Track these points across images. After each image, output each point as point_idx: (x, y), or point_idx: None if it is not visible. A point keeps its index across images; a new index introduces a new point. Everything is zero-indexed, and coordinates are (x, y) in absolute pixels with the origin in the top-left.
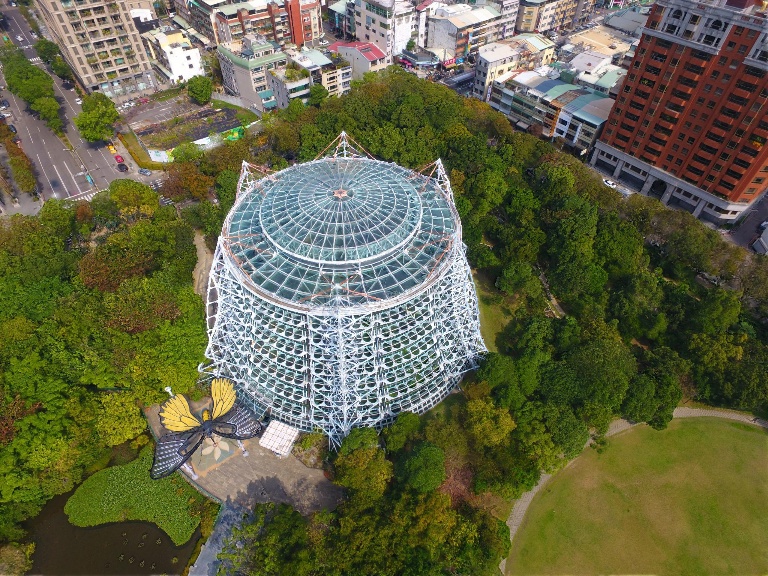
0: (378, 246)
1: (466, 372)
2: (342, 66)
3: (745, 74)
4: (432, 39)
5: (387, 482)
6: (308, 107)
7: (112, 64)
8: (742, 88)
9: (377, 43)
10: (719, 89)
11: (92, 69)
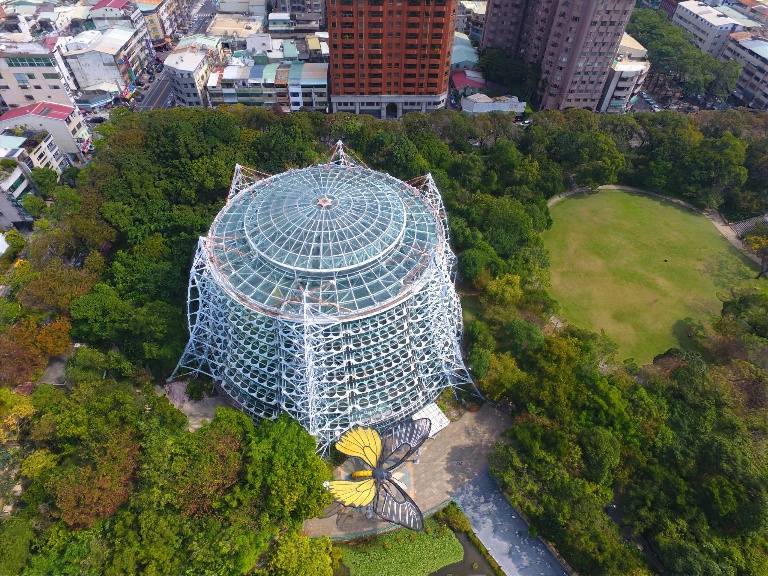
0: None
1: None
2: (41, 138)
3: (410, 6)
4: (83, 77)
5: None
6: None
7: None
8: (412, 16)
9: (50, 99)
10: (398, 23)
11: None
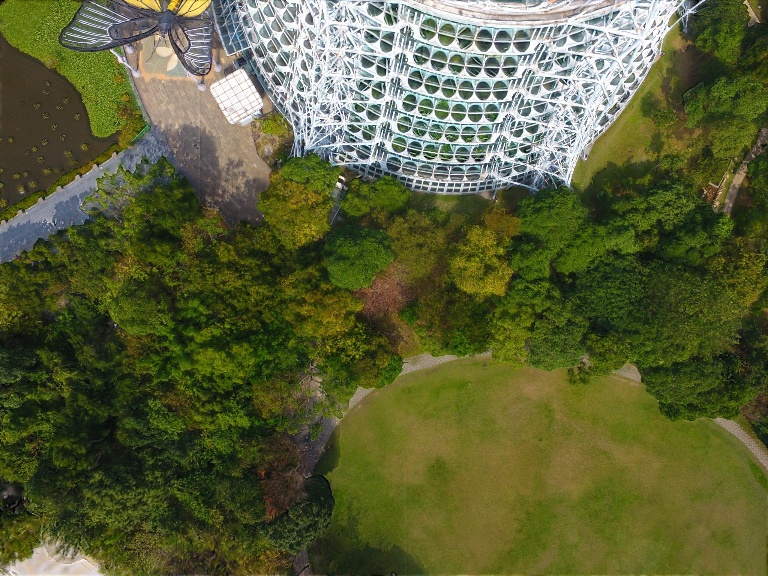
0: None
1: (522, 183)
2: None
3: None
4: None
5: None
6: None
7: None
8: None
9: None
10: None
11: None
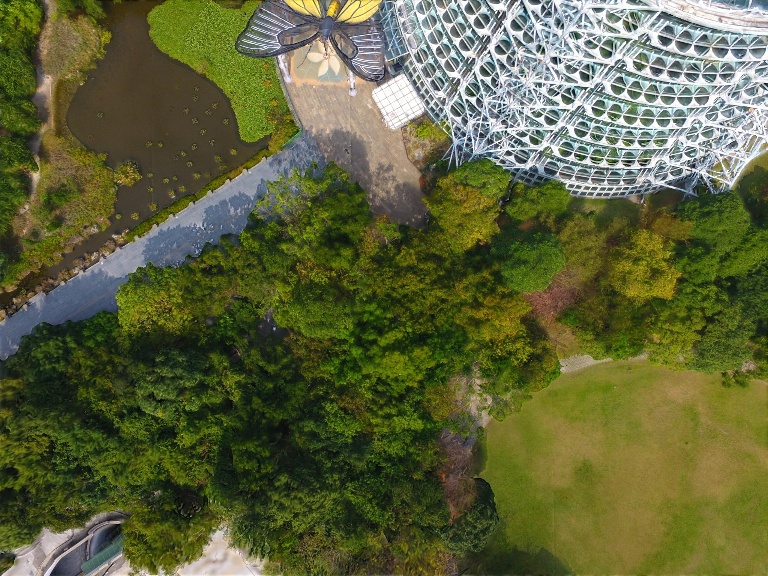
0: None
1: None
2: None
3: None
4: None
5: (478, 242)
6: None
7: None
8: None
9: None
10: None
11: None
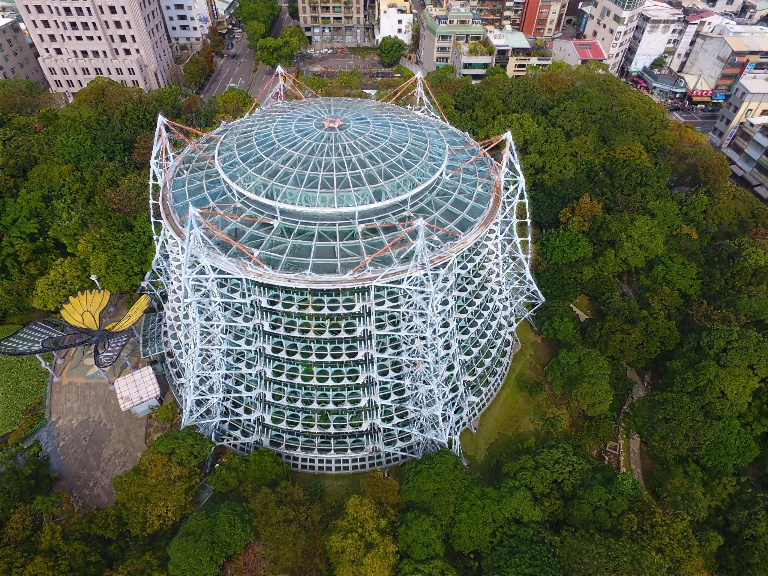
0: (321, 200)
1: None
2: (540, 55)
3: None
4: (692, 62)
5: None
6: (462, 79)
7: (330, 10)
8: None
9: (602, 42)
10: None
11: (311, 10)
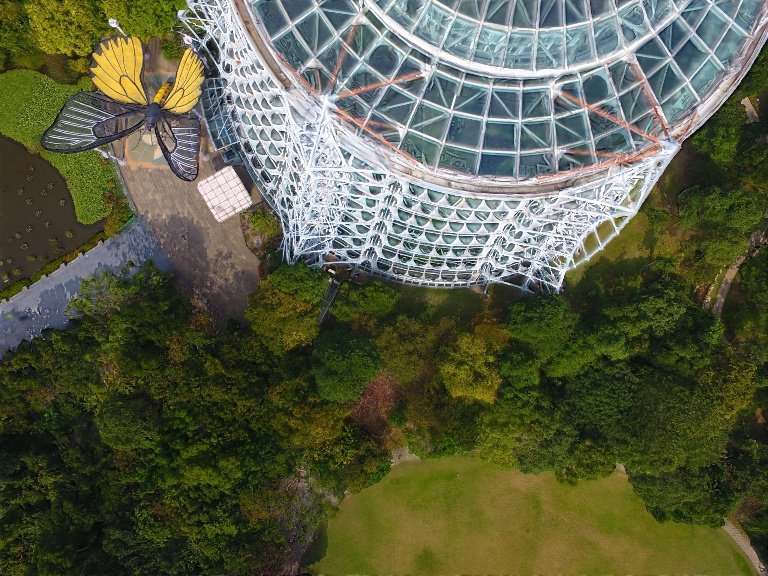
0: None
1: (514, 277)
2: None
3: None
4: None
5: None
6: None
7: None
8: None
9: None
10: None
11: None
